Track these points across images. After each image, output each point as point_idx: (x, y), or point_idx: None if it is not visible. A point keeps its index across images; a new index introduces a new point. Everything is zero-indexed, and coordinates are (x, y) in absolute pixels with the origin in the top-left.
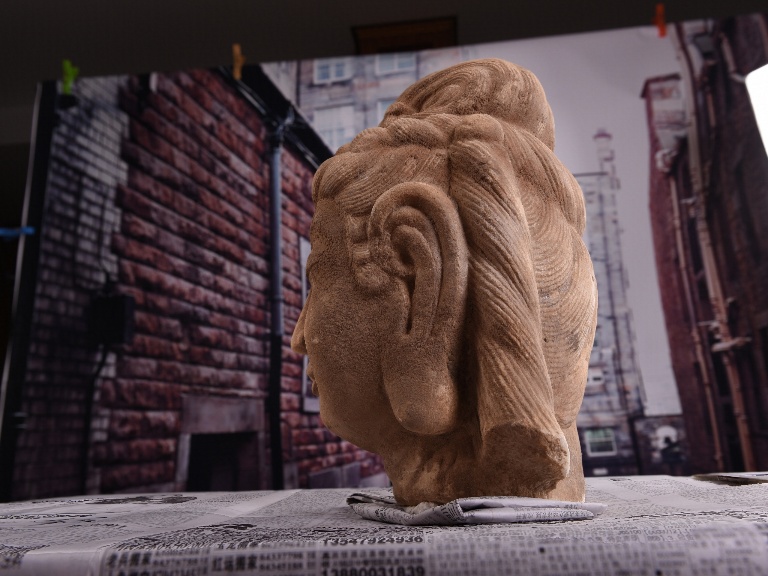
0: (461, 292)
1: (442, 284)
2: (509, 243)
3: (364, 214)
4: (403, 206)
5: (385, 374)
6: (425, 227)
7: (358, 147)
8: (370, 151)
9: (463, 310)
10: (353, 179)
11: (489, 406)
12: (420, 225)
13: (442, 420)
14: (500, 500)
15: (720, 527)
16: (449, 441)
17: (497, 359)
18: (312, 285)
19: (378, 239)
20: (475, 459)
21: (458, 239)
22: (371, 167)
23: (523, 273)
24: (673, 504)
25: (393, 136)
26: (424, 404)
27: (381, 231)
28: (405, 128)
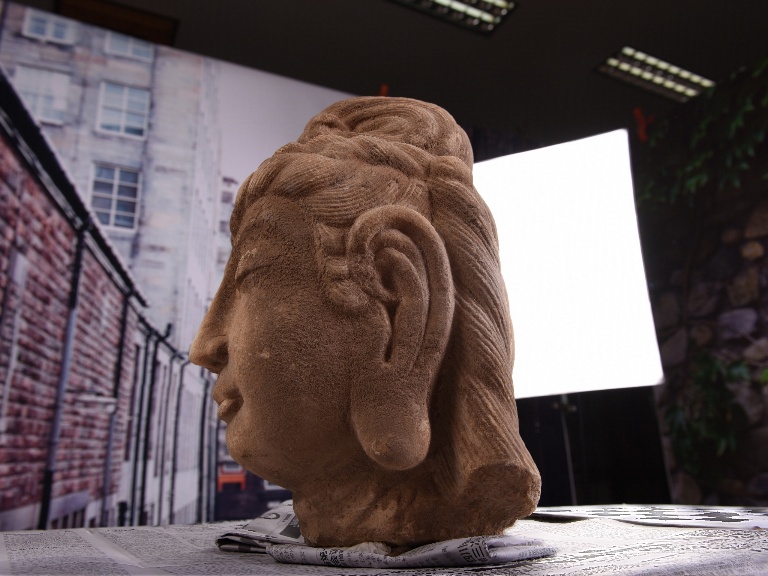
0: (449, 327)
1: (430, 316)
2: (498, 288)
3: (342, 226)
4: (392, 228)
5: (355, 402)
6: (415, 255)
7: (333, 152)
8: (347, 161)
9: (446, 345)
10: (328, 185)
11: (474, 444)
12: (410, 252)
13: (422, 456)
14: (503, 539)
15: (767, 559)
16: (408, 477)
17: (485, 399)
18: (251, 290)
19: (360, 256)
20: (442, 497)
21: (449, 274)
22: (349, 178)
23: (506, 319)
24: (554, 539)
25: (369, 152)
26: (408, 438)
27: (366, 249)
28: (383, 148)
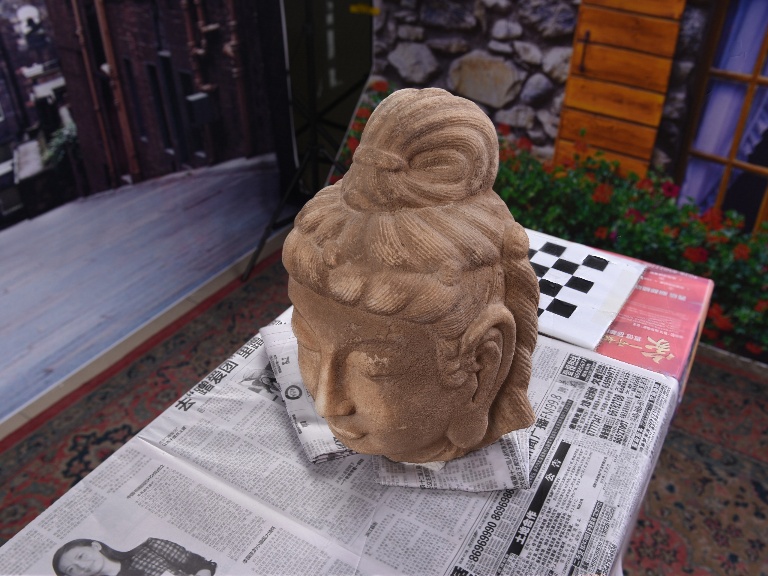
0: None
1: None
2: None
3: None
4: (489, 329)
5: None
6: None
7: None
8: None
9: None
10: None
11: (510, 419)
12: None
13: None
14: None
15: (643, 464)
16: None
17: None
18: (384, 385)
19: None
20: None
21: None
22: (463, 298)
23: None
24: None
25: (470, 261)
26: None
27: None
28: (480, 254)
